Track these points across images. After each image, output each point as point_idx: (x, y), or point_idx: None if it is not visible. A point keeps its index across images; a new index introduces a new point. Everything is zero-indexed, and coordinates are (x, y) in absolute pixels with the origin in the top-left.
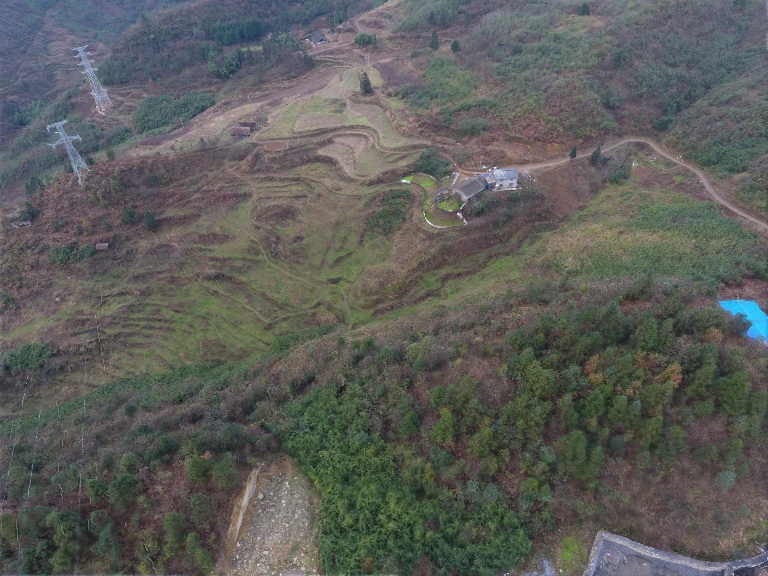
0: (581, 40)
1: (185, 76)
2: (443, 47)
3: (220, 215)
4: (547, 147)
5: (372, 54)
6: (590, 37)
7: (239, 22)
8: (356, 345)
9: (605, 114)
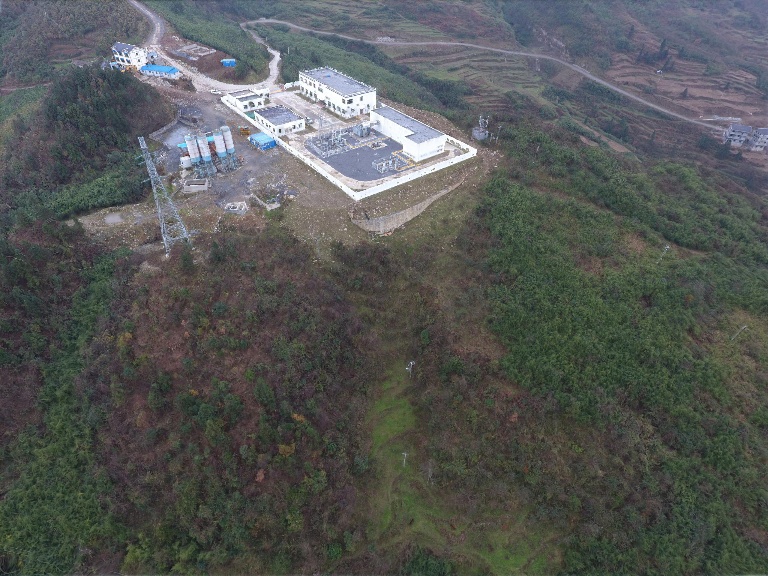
0: None
1: None
2: None
3: None
4: None
5: None
6: None
7: None
8: None
9: None
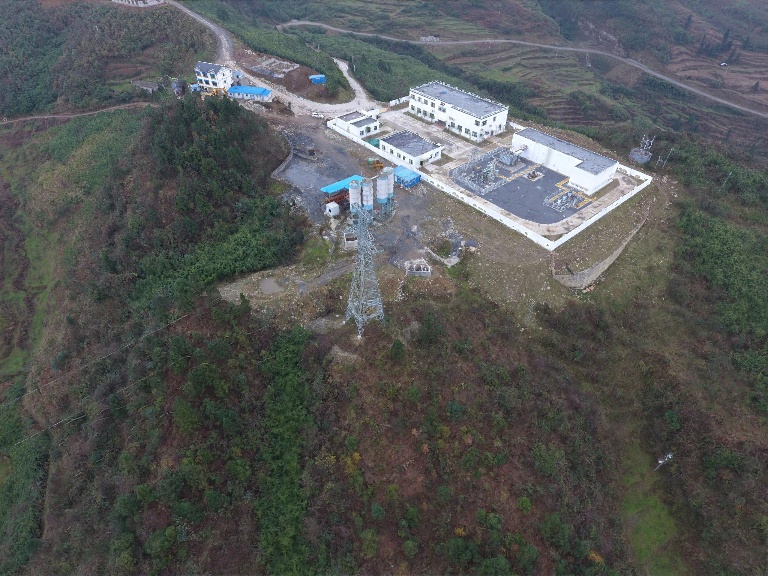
0: None
1: None
2: None
3: None
4: None
5: None
6: None
7: None
8: (94, 284)
9: None
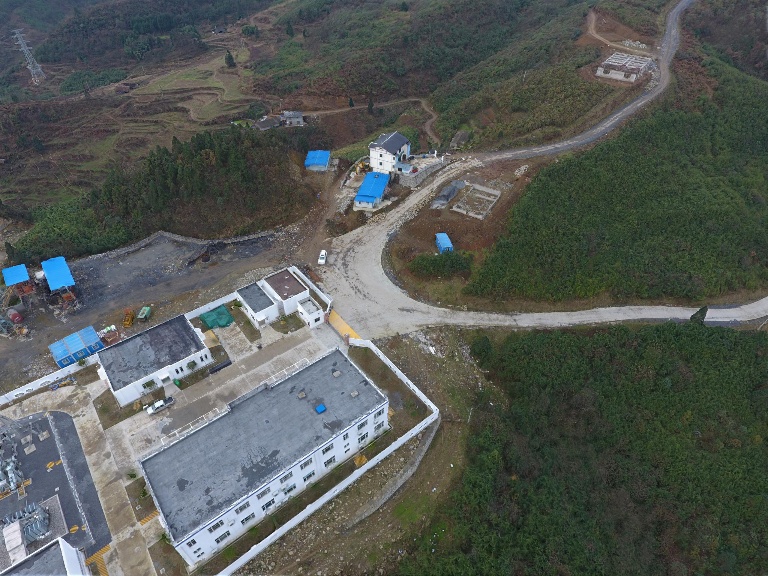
0: (388, 27)
1: (107, 57)
2: (301, 35)
3: (92, 143)
4: (336, 99)
5: (255, 42)
6: (395, 25)
7: (154, 16)
8: None
9: (388, 79)
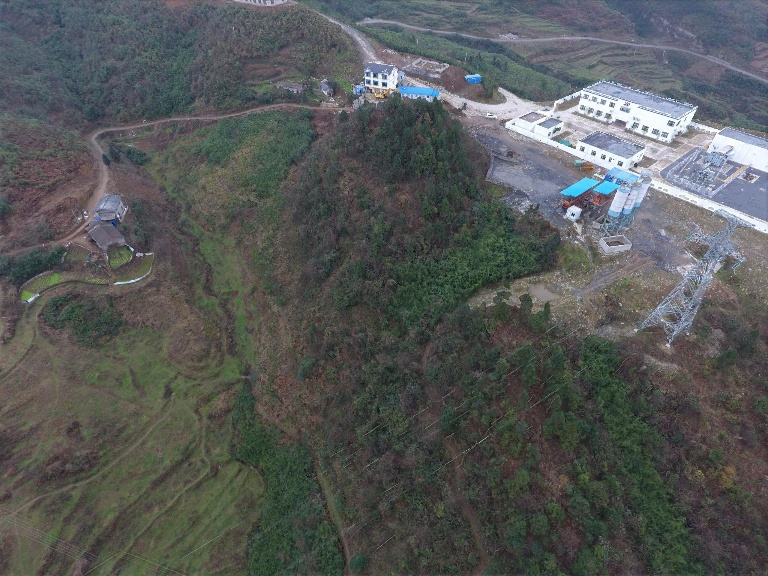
0: None
1: None
2: None
3: None
4: (81, 173)
5: None
6: None
7: None
8: (343, 291)
9: (61, 128)
